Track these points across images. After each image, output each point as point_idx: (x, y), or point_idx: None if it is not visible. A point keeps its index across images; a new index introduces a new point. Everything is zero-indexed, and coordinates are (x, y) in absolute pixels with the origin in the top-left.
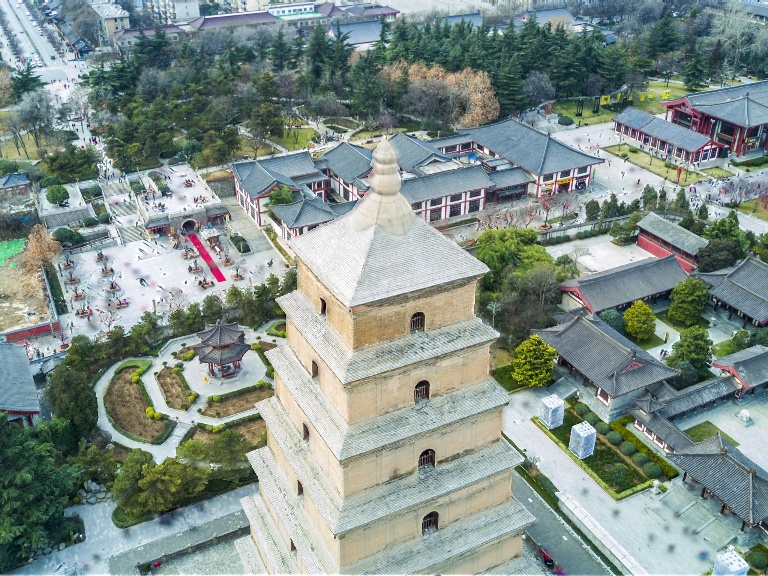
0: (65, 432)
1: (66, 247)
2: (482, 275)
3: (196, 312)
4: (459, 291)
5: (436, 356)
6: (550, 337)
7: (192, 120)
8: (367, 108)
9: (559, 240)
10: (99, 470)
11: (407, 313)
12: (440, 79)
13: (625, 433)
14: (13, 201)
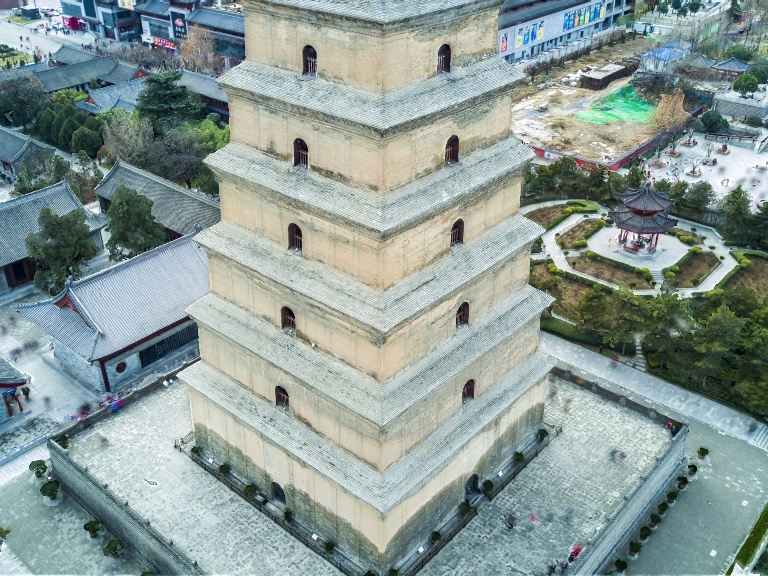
0: None
1: (708, 131)
2: None
3: (680, 191)
4: None
5: (313, 11)
6: None
7: None
8: None
9: None
10: None
11: None
12: None
13: None
14: (718, 84)
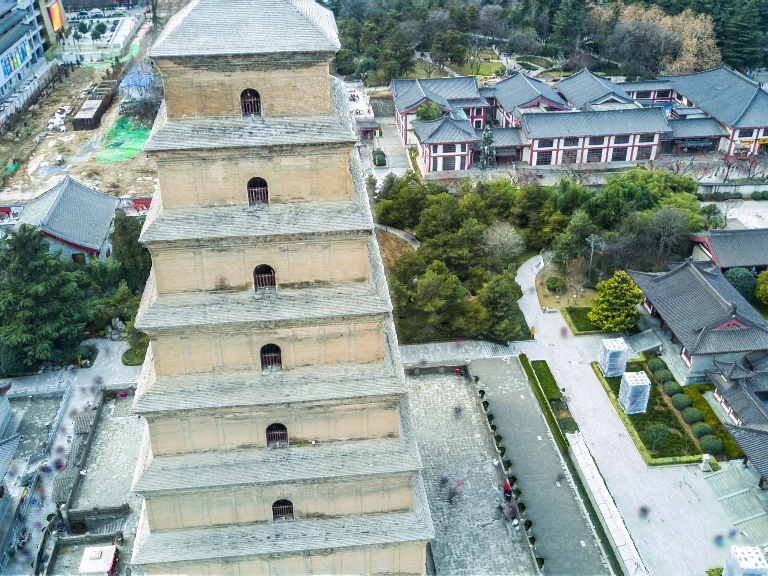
0: (114, 273)
1: None
2: (332, 56)
3: None
4: (305, 73)
5: (267, 146)
6: (646, 281)
7: (381, 43)
8: (563, 46)
9: (726, 196)
10: (125, 310)
11: (235, 86)
12: (656, 22)
13: (698, 400)
14: None
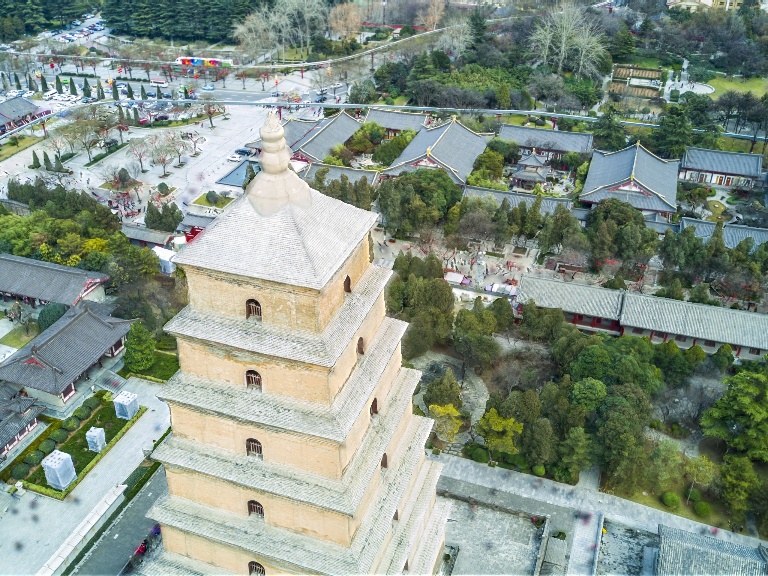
0: None
1: None
2: None
3: None
4: None
5: None
6: None
7: None
8: None
9: None
10: None
11: None
12: None
13: None
14: None
